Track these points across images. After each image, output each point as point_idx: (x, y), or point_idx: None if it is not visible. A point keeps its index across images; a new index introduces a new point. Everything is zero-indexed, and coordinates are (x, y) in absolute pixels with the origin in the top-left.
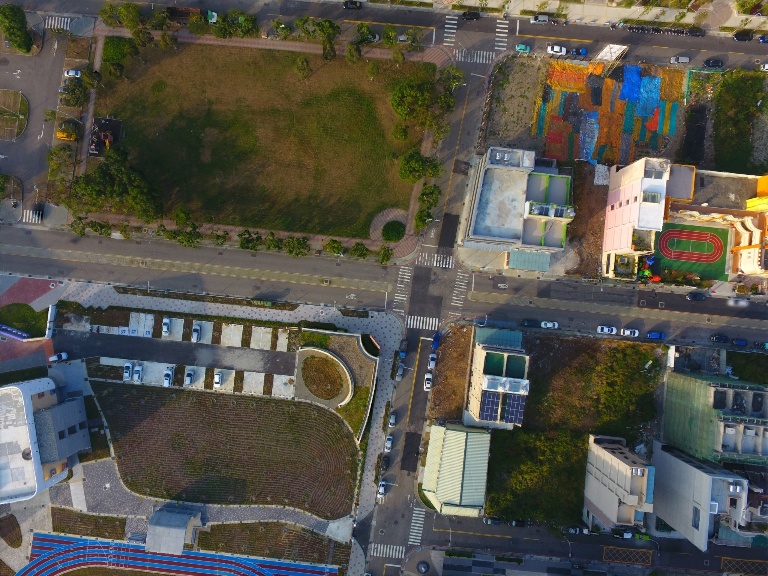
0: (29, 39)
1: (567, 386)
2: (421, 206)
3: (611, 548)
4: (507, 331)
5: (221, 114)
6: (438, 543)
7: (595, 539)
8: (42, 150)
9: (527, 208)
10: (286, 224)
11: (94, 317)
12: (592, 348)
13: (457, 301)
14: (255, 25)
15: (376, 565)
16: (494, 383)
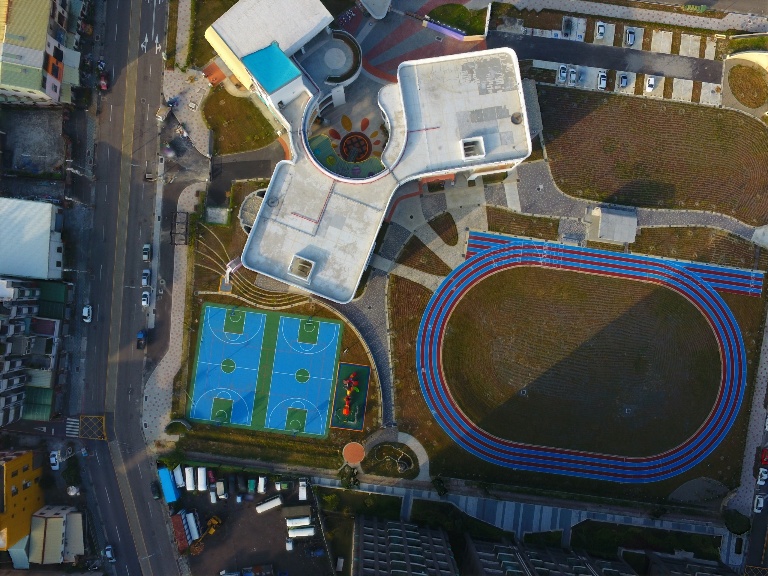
0: None
1: None
2: None
3: None
4: None
5: None
6: None
7: None
8: None
9: None
10: None
11: (528, 19)
12: None
13: None
14: None
15: None
16: None
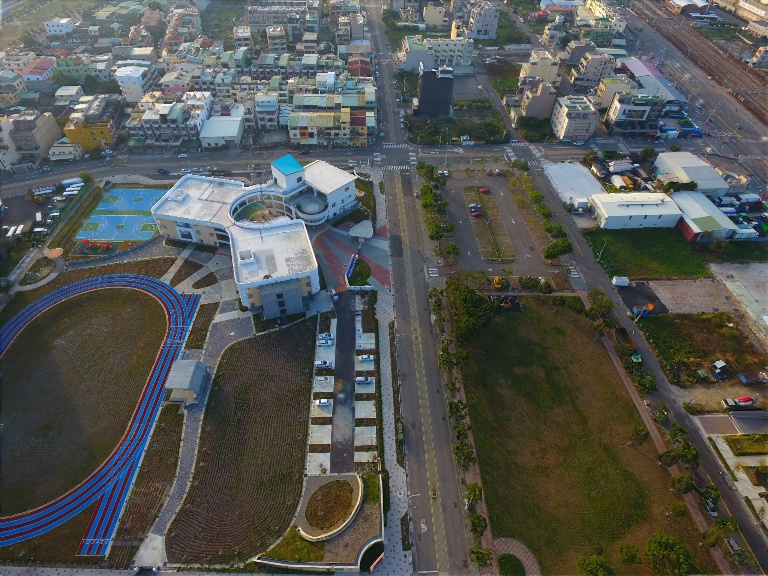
0: (554, 256)
1: None
2: None
3: None
4: None
5: (559, 377)
6: None
7: None
8: None
9: None
10: (482, 444)
11: (367, 311)
12: None
13: None
14: (651, 390)
15: None
16: None
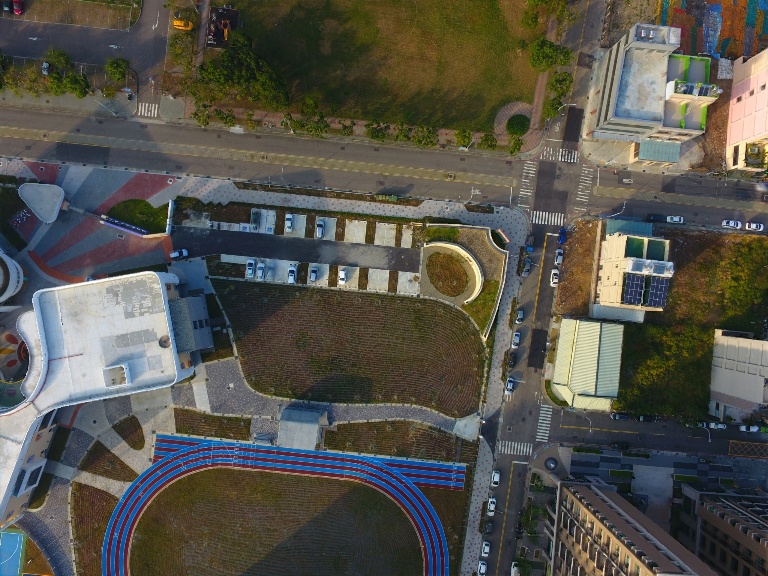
0: None
1: (691, 282)
2: (545, 100)
3: (736, 442)
4: (638, 222)
5: (341, 5)
6: (565, 440)
7: (721, 433)
8: (157, 40)
9: (671, 87)
10: (409, 118)
11: (214, 213)
12: (716, 243)
13: (582, 196)
14: None
15: (504, 462)
16: (639, 265)
